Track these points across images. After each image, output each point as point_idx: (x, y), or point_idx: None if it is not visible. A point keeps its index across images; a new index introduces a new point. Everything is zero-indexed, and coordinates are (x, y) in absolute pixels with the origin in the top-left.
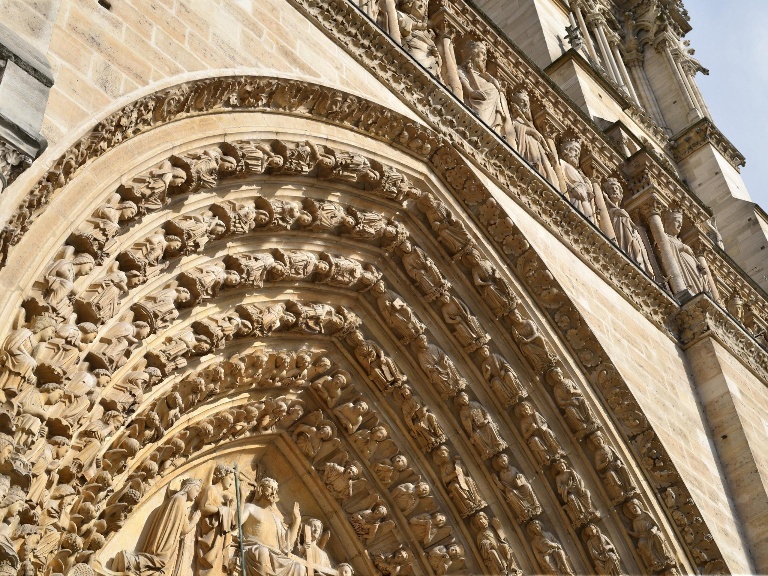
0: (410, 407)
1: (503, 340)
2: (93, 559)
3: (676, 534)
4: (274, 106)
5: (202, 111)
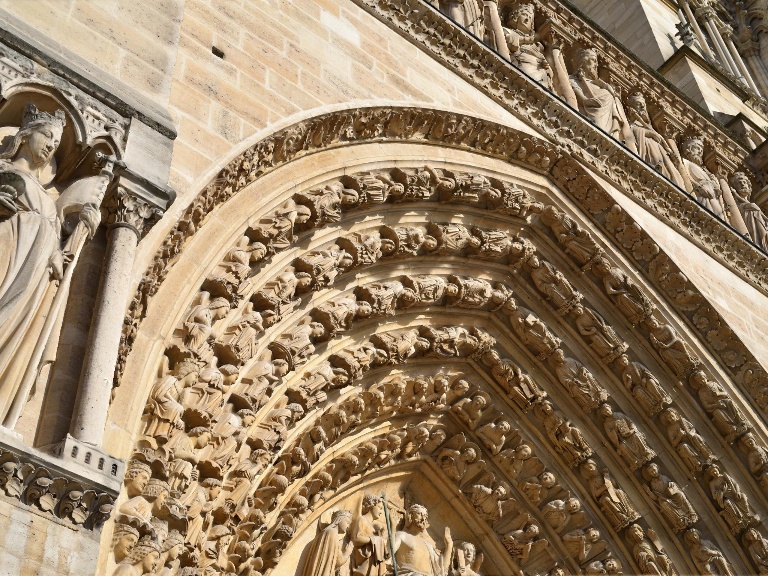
0: (553, 423)
1: (641, 347)
2: None
3: None
4: (390, 135)
5: (320, 147)
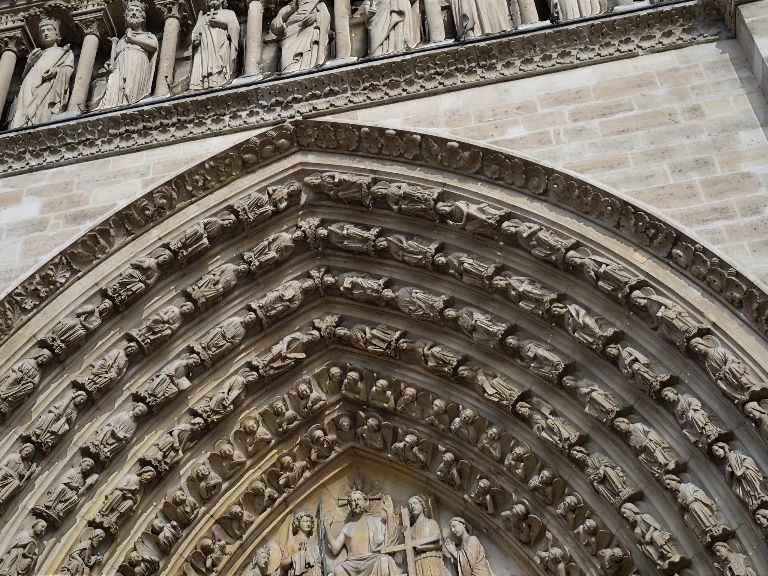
0: None
1: (455, 234)
2: None
3: (705, 290)
4: (86, 266)
5: (2, 340)
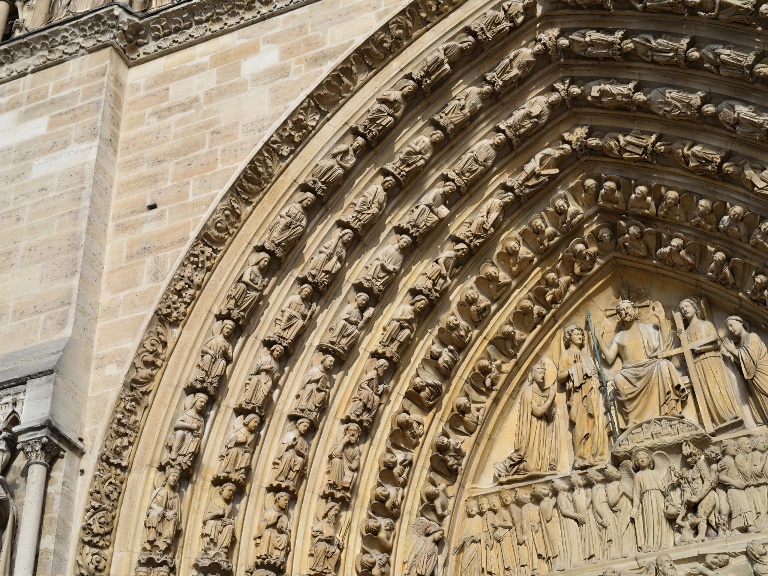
0: None
1: (707, 26)
2: (438, 503)
3: None
4: (333, 106)
5: (266, 188)
